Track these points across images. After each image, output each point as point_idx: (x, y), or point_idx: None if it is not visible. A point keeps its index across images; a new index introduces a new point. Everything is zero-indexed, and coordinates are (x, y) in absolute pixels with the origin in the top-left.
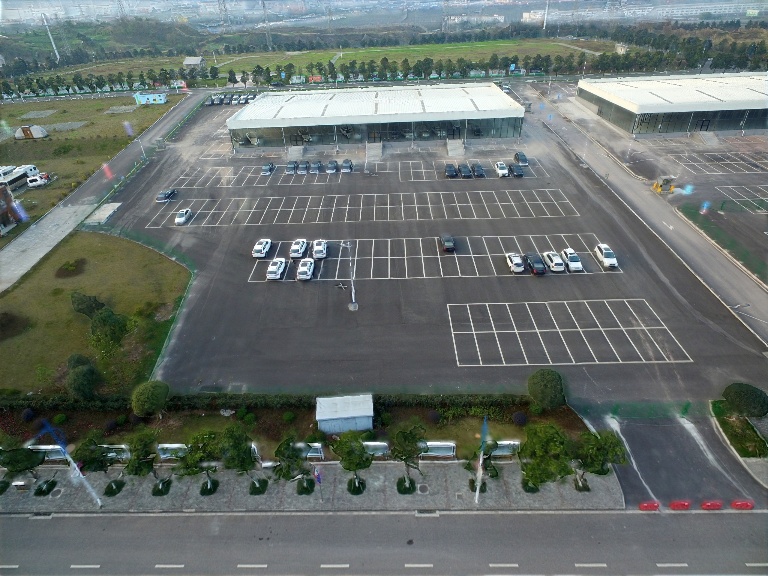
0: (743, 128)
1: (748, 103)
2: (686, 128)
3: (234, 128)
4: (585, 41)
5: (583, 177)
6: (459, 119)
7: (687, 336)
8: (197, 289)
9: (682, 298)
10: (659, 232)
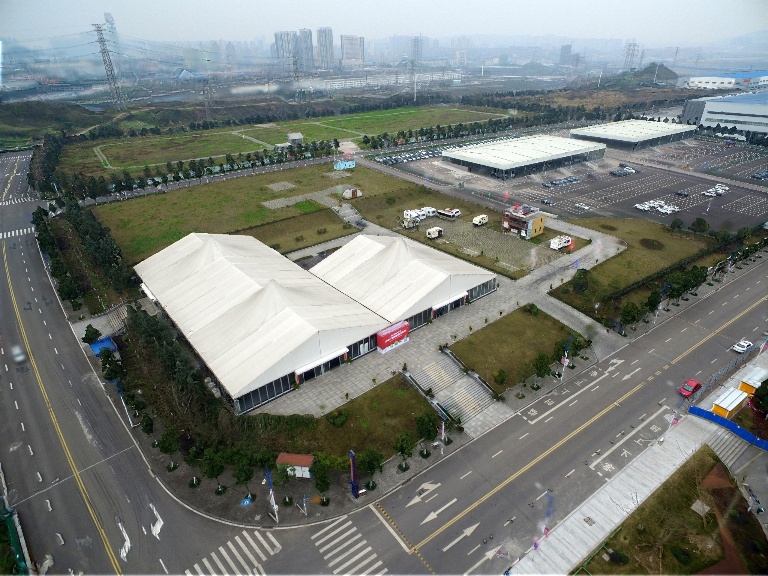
0: (659, 145)
1: (661, 134)
2: (646, 147)
3: (507, 169)
4: (464, 107)
5: None
6: (587, 152)
7: None
8: (658, 222)
9: None
10: None
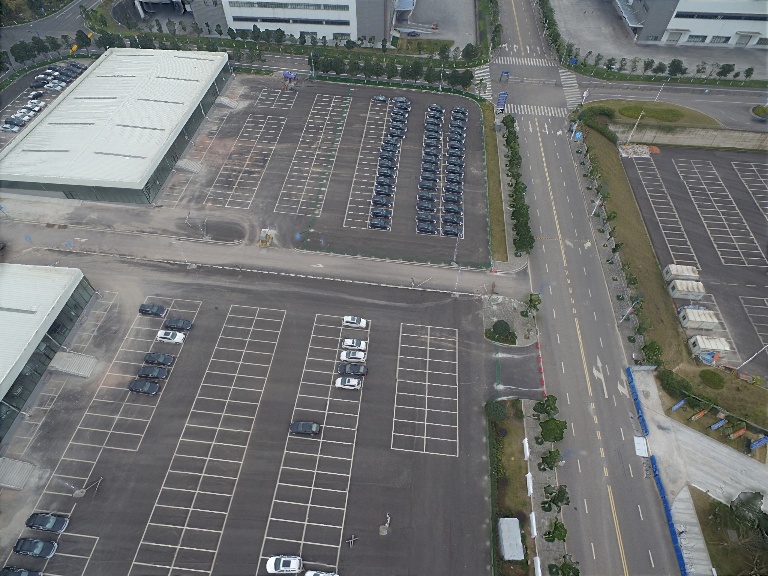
0: (189, 140)
1: (181, 124)
2: (169, 169)
3: None
4: None
5: (216, 278)
6: (40, 341)
7: (437, 321)
8: None
9: (403, 304)
10: (326, 276)
